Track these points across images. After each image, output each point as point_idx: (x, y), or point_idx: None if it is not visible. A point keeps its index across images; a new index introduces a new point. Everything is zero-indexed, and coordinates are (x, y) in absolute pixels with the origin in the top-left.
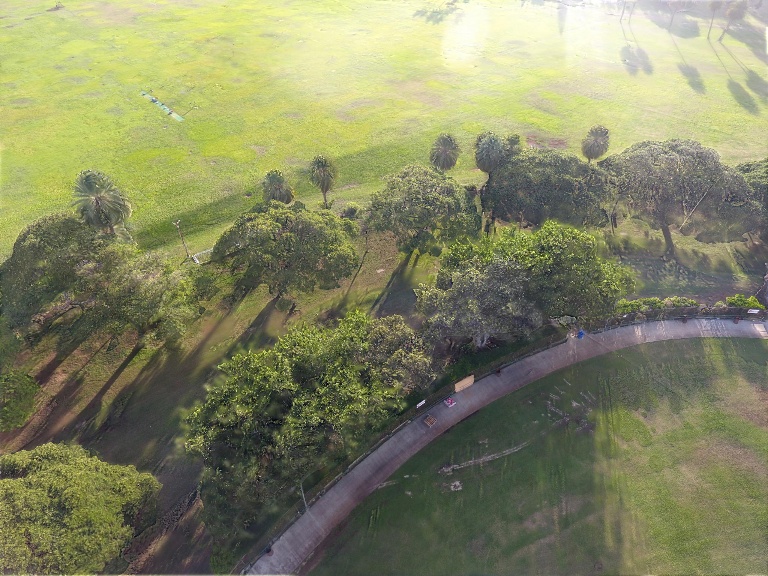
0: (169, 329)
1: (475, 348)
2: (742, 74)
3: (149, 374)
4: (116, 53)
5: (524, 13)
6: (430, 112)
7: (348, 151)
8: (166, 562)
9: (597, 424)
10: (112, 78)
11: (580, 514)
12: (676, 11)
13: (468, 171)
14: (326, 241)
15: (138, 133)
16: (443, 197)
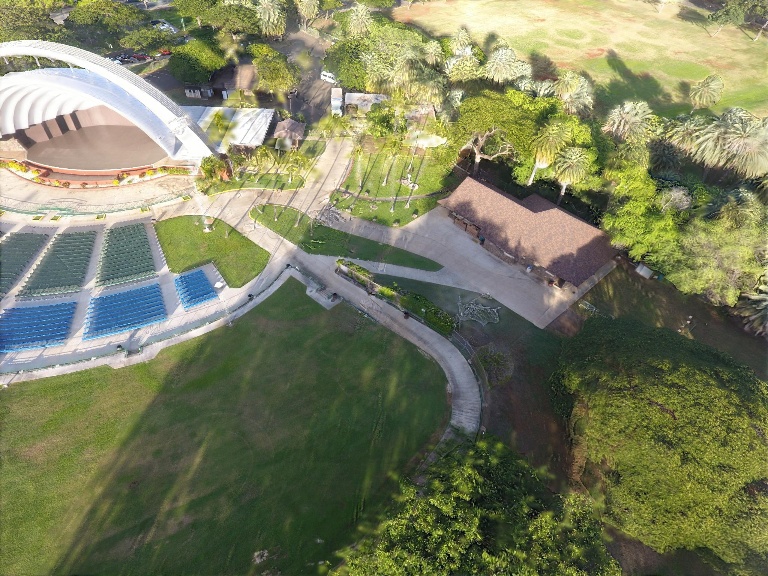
0: None
1: None
2: None
3: None
4: None
5: None
6: None
7: None
8: (552, 471)
9: None
10: None
11: (122, 536)
12: None
13: None
14: None
15: None
16: None
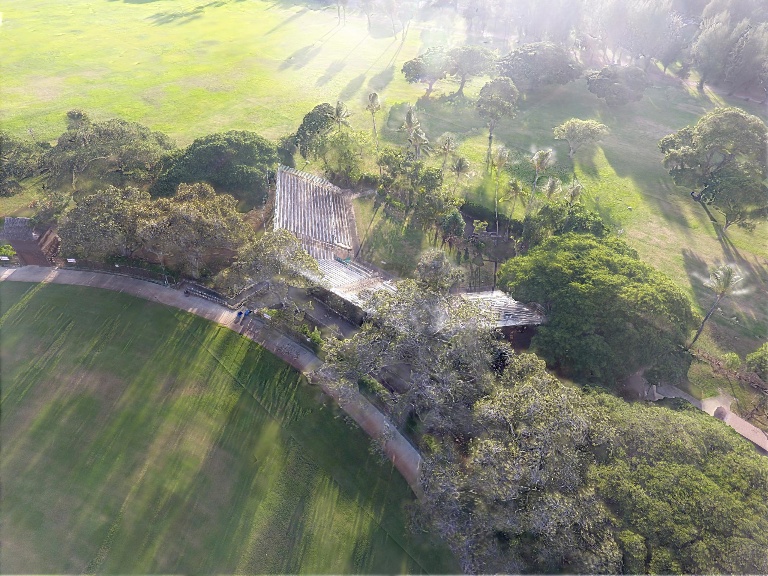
0: None
1: None
2: (380, 69)
3: None
4: None
5: (258, 16)
6: (31, 104)
7: None
8: None
9: None
10: None
11: None
12: (369, 14)
13: None
14: None
15: None
16: None
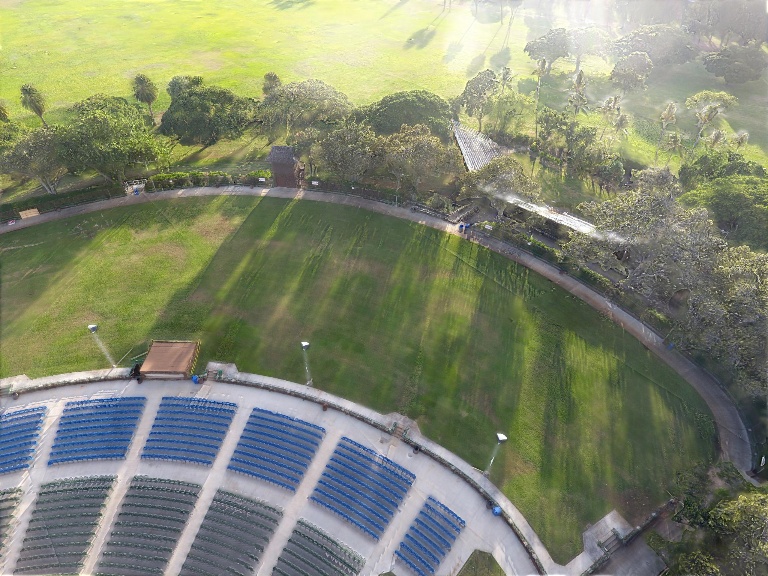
0: None
1: (47, 194)
2: (497, 50)
3: None
4: None
5: (367, 3)
6: (203, 73)
7: None
8: None
9: (100, 235)
10: None
11: (44, 273)
12: (477, 0)
13: None
14: None
15: None
16: None
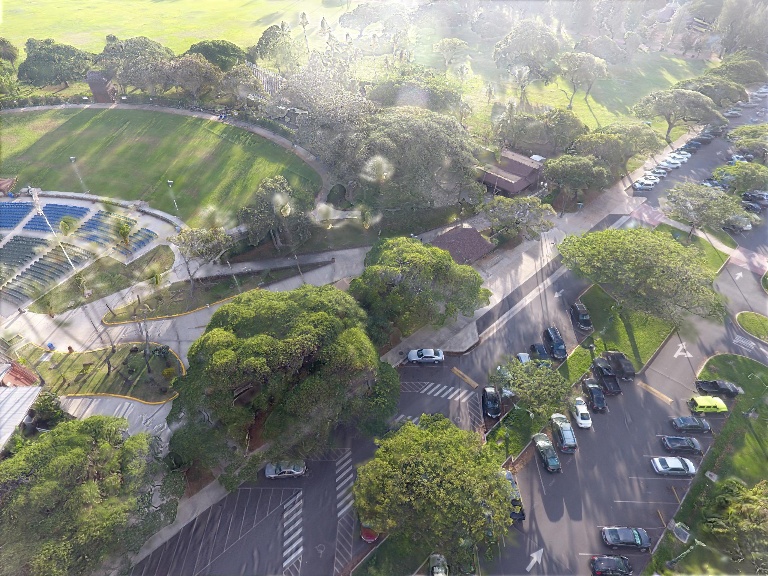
0: None
1: None
2: None
3: None
4: None
5: None
6: None
7: None
8: None
9: None
10: None
11: None
12: None
13: None
14: None
15: None
16: None
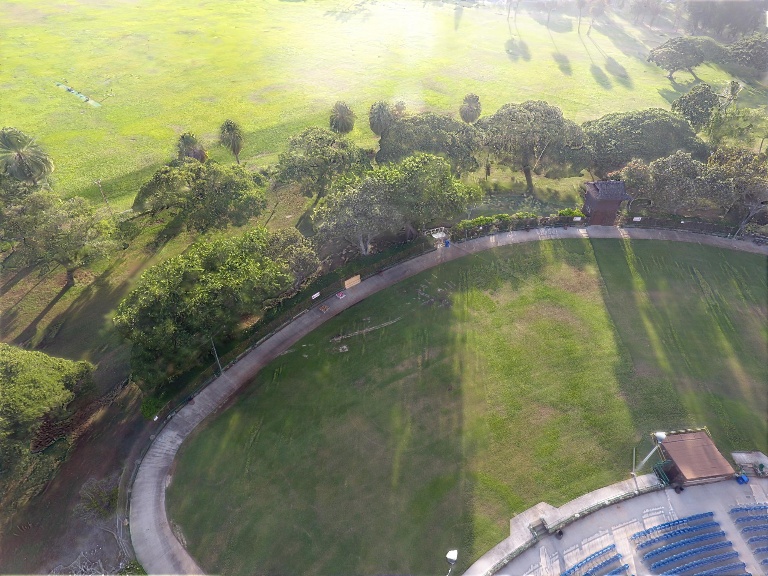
0: (96, 256)
1: (361, 255)
2: (602, 60)
3: (80, 305)
4: (26, 49)
5: (425, 13)
6: (336, 94)
7: (261, 127)
8: (104, 426)
9: (455, 301)
10: (24, 71)
11: (438, 358)
12: (551, 10)
13: (369, 139)
14: (236, 187)
15: (55, 118)
16: (338, 149)
